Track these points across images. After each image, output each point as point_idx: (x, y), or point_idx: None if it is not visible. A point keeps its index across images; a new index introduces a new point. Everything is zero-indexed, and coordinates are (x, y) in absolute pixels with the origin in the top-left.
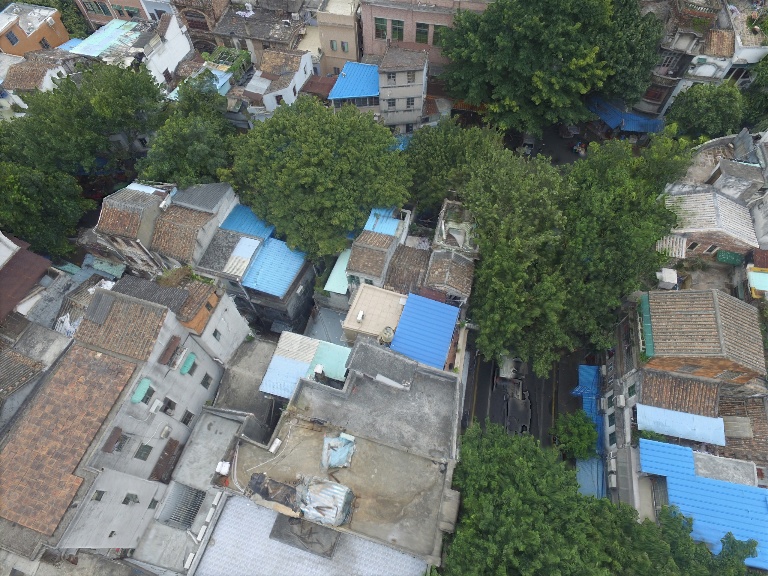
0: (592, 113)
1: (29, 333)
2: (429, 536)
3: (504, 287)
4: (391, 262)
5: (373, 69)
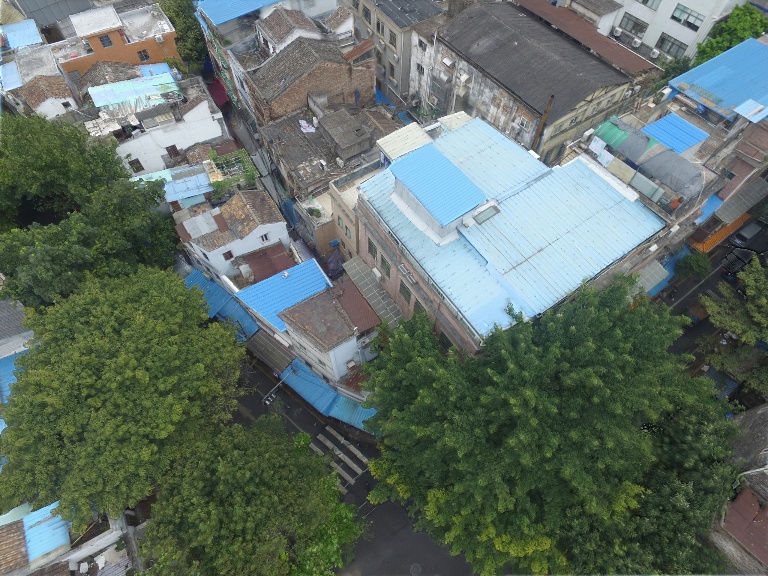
0: None
1: None
2: None
3: None
4: None
5: None
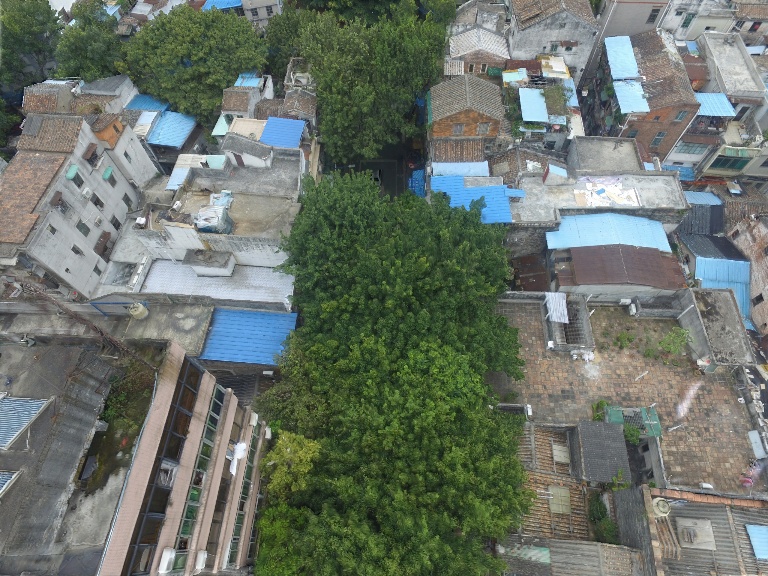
0: None
1: None
2: None
3: None
4: (257, 105)
5: None
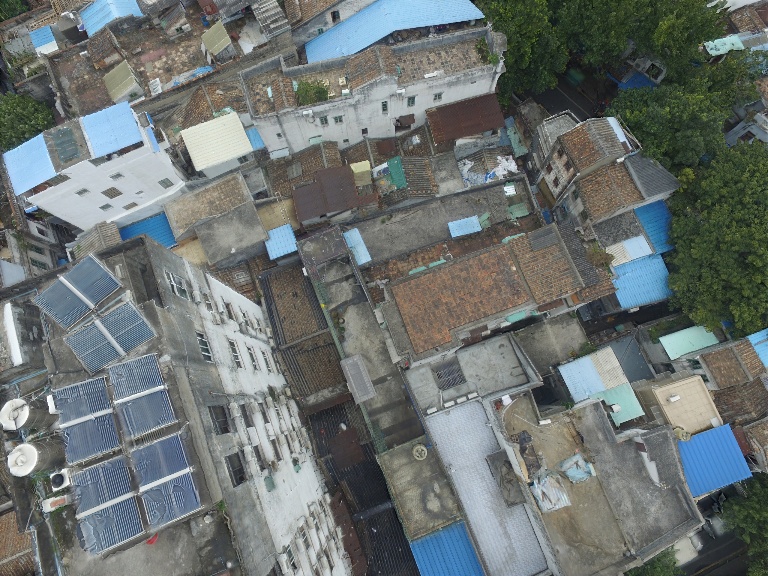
0: None
1: (445, 157)
2: (579, 574)
3: None
4: None
5: None
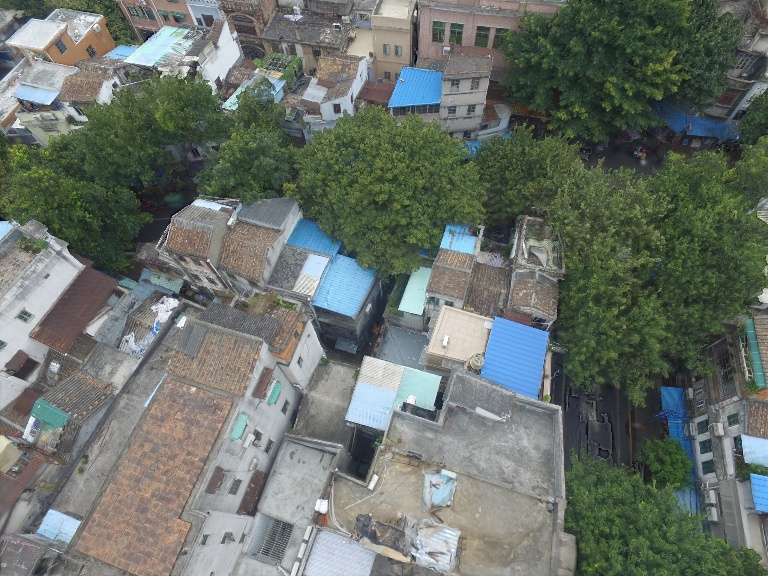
0: (661, 118)
1: (97, 354)
2: None
3: (602, 313)
4: (470, 282)
5: (431, 75)
